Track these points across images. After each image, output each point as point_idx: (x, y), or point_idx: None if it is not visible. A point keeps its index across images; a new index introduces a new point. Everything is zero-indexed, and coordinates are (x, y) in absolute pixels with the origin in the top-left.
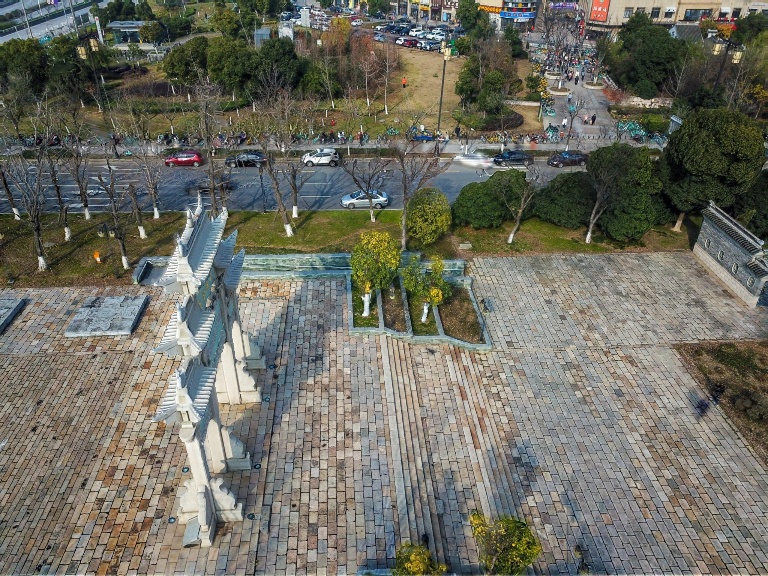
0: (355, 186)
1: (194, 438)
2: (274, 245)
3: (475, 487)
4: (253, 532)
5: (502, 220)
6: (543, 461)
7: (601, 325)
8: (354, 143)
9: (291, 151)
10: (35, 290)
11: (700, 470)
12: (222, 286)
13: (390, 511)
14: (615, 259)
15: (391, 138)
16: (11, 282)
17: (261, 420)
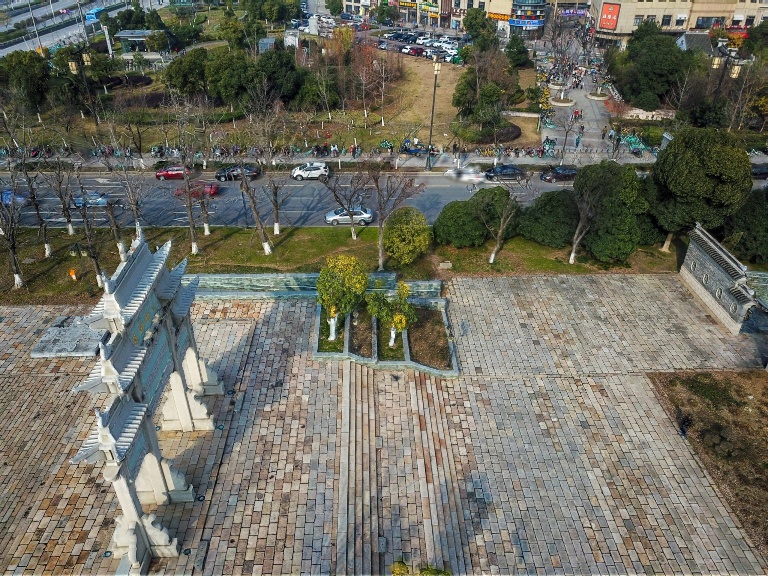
0: None
1: (119, 476)
2: (251, 263)
3: (422, 524)
4: (187, 569)
5: (485, 239)
6: (497, 497)
7: (575, 351)
8: (347, 156)
9: (282, 164)
10: (9, 308)
11: (660, 510)
12: (167, 316)
13: (329, 549)
14: (598, 281)
15: (384, 151)
16: None
17: (211, 449)
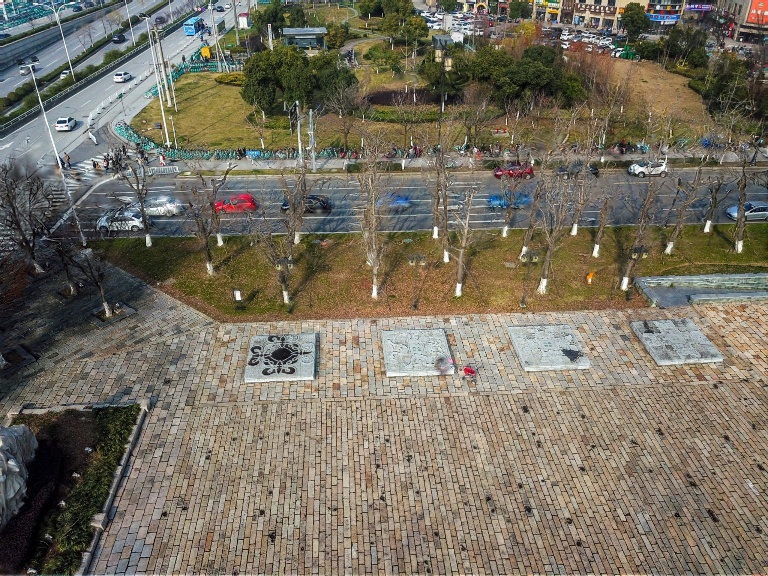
0: None
1: None
2: (737, 262)
3: None
4: None
5: None
6: None
7: None
8: None
9: (611, 162)
10: (558, 314)
11: None
12: None
13: None
14: None
15: None
16: (523, 306)
17: None
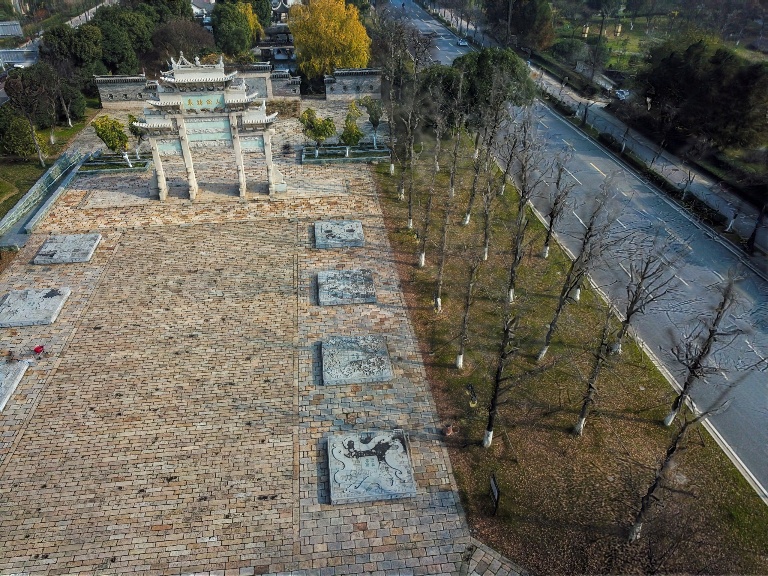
0: None
1: None
2: None
3: (261, 154)
4: None
5: None
6: None
7: None
8: None
9: None
10: None
11: None
12: None
13: None
14: None
15: None
16: None
17: None
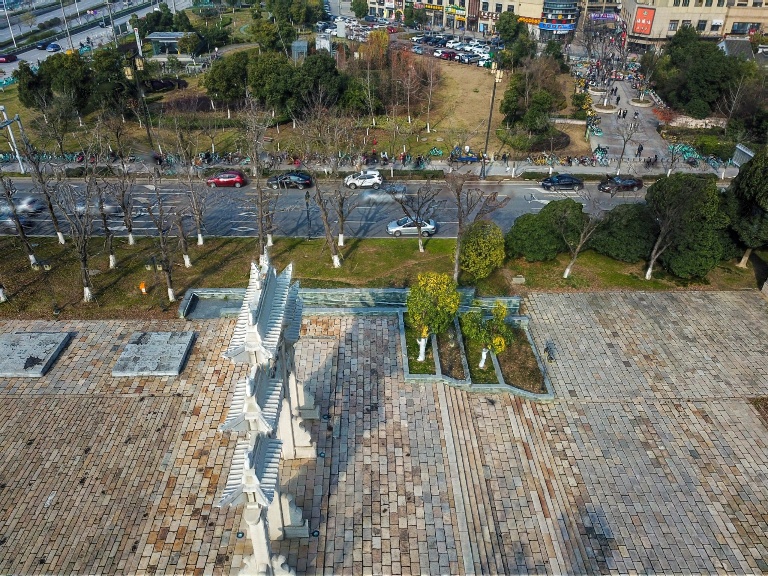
0: (400, 211)
1: (259, 519)
2: (321, 277)
3: (548, 564)
4: None
5: (556, 253)
6: (618, 533)
7: (669, 374)
8: (397, 163)
9: None
10: (81, 322)
11: None
12: (283, 342)
13: None
14: (678, 298)
15: (434, 158)
16: (56, 313)
17: (317, 479)
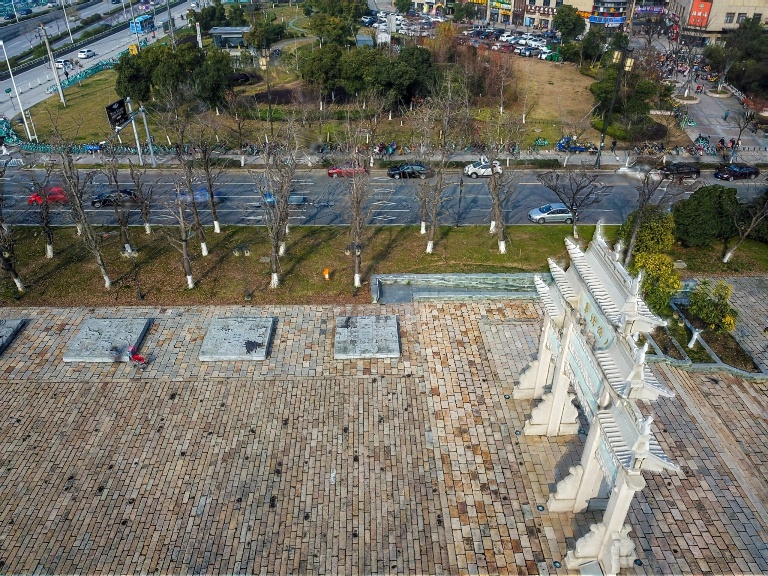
0: (531, 199)
1: None
2: (492, 263)
3: None
4: None
5: None
6: None
7: None
8: (505, 154)
9: (450, 162)
10: (276, 308)
11: None
12: None
13: None
14: None
15: None
16: (248, 299)
17: None
